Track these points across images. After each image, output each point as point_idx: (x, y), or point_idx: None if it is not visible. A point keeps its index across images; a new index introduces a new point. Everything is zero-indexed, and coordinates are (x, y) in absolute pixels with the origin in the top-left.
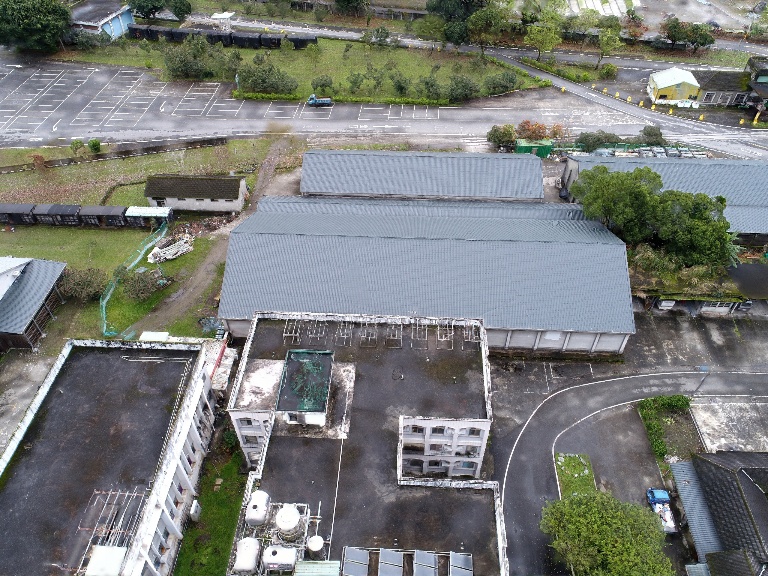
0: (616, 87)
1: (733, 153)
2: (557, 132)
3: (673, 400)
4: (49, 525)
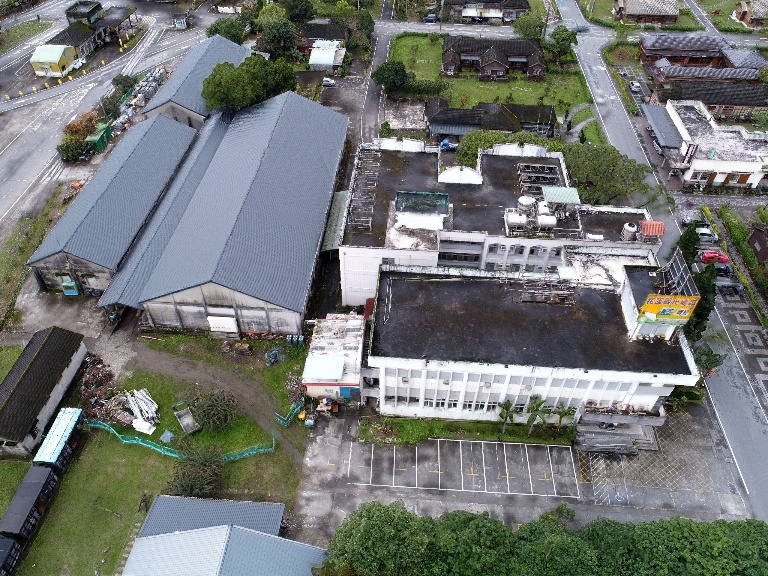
0: (18, 88)
1: (158, 63)
2: (92, 118)
3: (386, 127)
4: (542, 328)
